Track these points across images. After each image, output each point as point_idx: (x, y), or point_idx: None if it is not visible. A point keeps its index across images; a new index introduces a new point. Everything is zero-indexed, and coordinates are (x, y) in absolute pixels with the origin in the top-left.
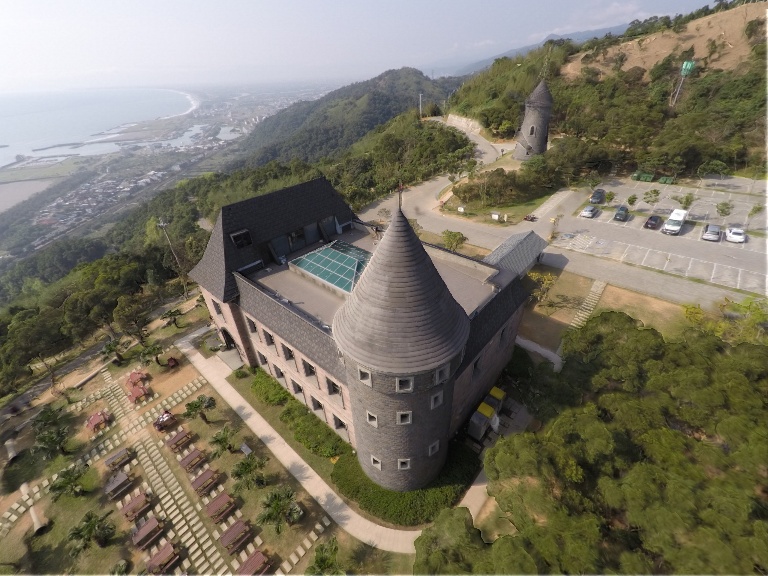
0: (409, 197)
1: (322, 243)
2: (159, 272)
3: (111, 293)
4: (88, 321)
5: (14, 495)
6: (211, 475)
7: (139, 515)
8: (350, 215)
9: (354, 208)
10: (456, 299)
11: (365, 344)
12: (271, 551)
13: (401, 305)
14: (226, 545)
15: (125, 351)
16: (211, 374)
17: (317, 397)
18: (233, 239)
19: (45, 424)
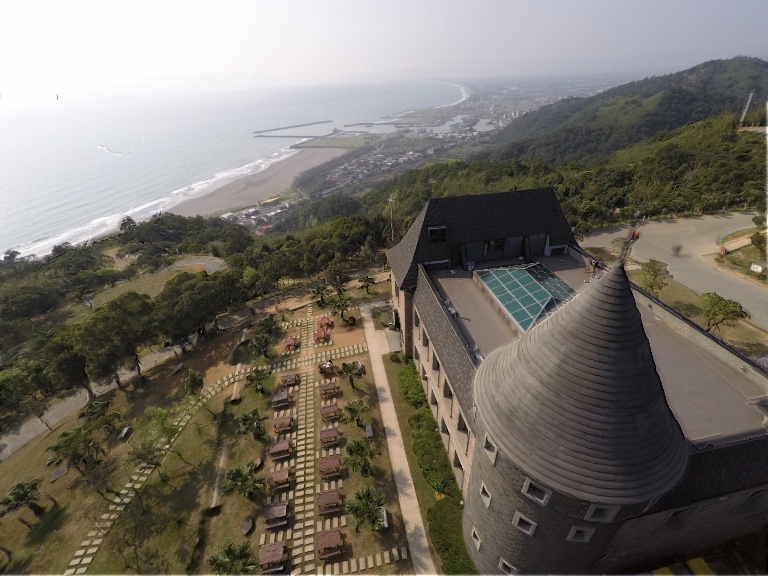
0: (670, 231)
1: (521, 260)
2: (378, 239)
3: (336, 247)
4: (316, 263)
5: (233, 368)
6: (335, 435)
7: (282, 431)
8: (568, 238)
9: (582, 228)
10: (682, 405)
11: (503, 413)
12: (348, 539)
13: (570, 393)
14: (319, 504)
15: (327, 297)
16: (373, 345)
17: (447, 422)
18: (429, 232)
19: (264, 328)
